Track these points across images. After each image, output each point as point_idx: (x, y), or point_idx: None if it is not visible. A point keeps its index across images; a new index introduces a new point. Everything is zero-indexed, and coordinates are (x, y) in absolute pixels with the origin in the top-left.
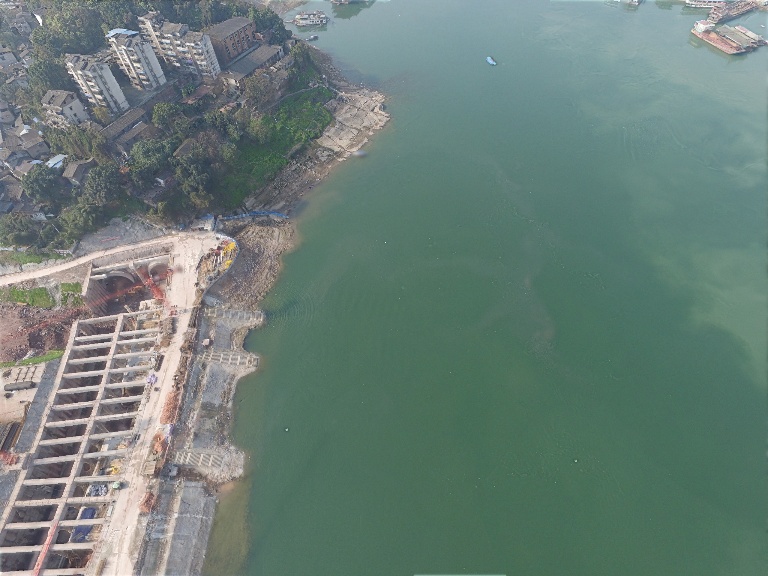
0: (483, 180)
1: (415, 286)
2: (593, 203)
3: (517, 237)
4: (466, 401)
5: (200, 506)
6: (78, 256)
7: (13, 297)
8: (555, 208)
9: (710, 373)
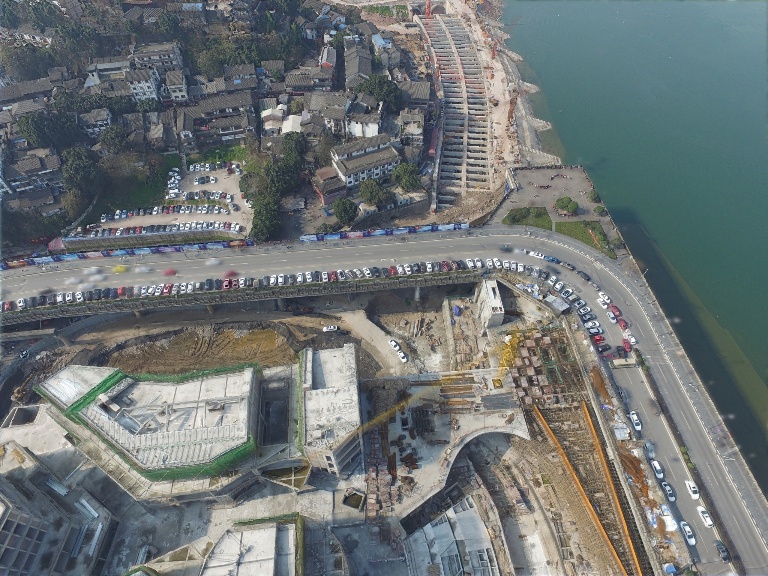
0: None
1: (577, 18)
2: None
3: (625, 6)
4: (616, 46)
5: (512, 63)
6: None
7: (371, 10)
8: None
9: None
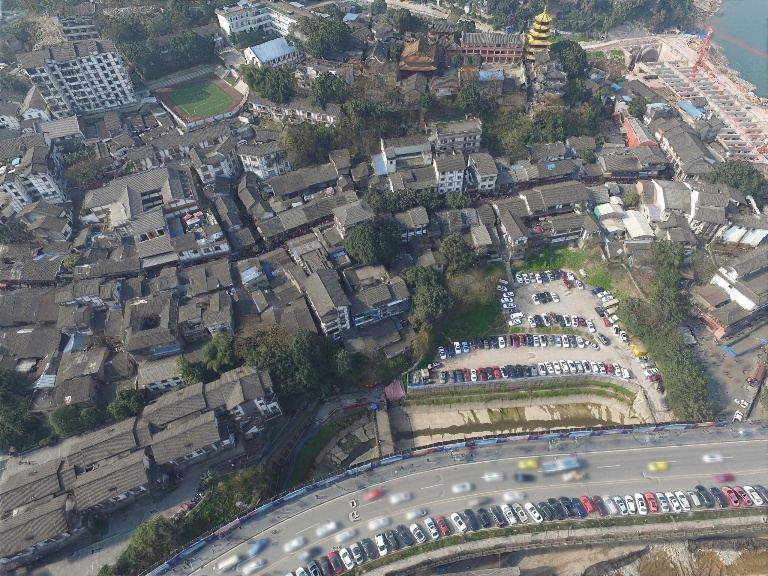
0: None
1: None
2: None
3: None
4: None
5: None
6: (607, 41)
7: None
8: None
9: None
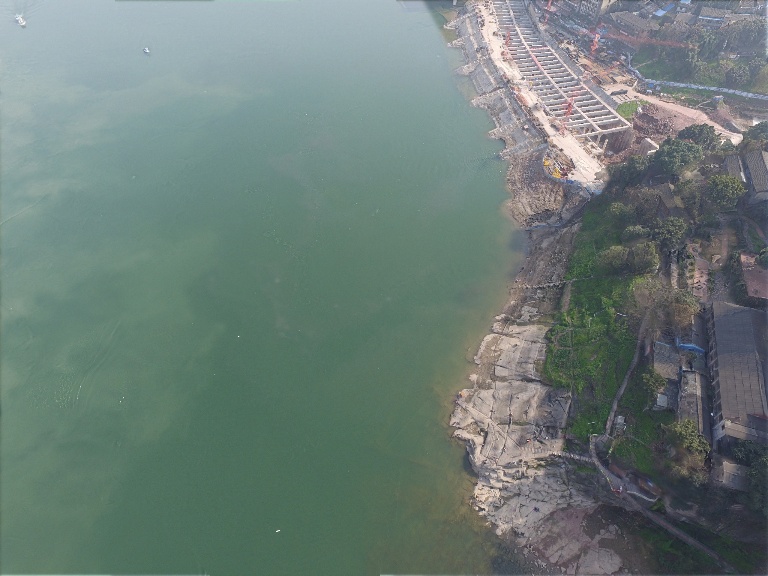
0: (314, 286)
1: (389, 181)
2: (207, 261)
3: (297, 223)
4: (357, 131)
5: None
6: None
7: None
8: (249, 251)
9: (215, 145)
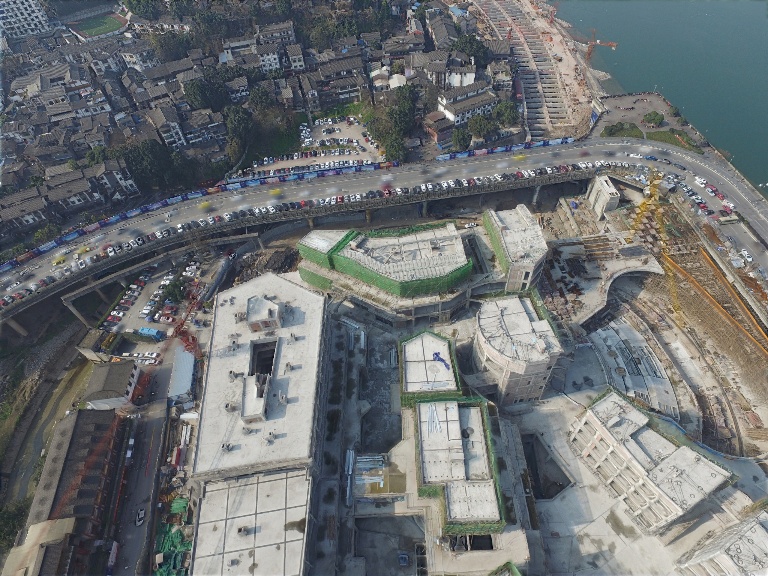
0: None
1: None
2: None
3: None
4: (654, 9)
5: None
6: None
7: None
8: None
9: None
